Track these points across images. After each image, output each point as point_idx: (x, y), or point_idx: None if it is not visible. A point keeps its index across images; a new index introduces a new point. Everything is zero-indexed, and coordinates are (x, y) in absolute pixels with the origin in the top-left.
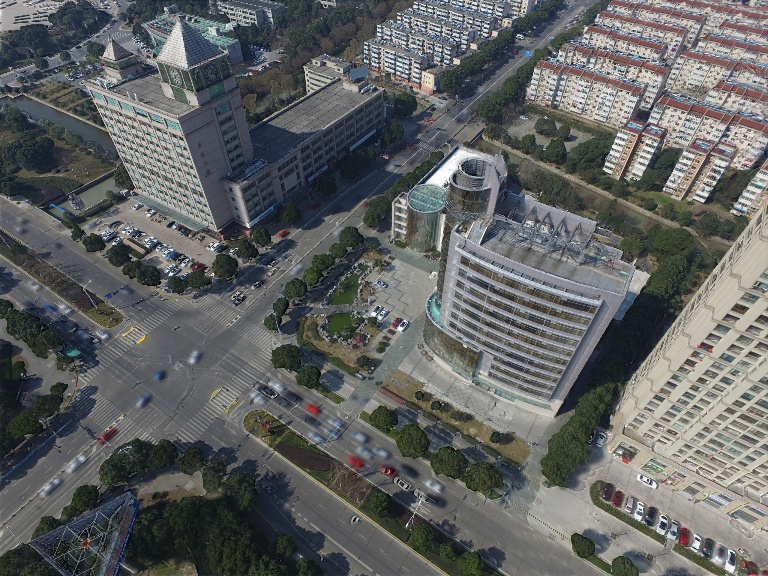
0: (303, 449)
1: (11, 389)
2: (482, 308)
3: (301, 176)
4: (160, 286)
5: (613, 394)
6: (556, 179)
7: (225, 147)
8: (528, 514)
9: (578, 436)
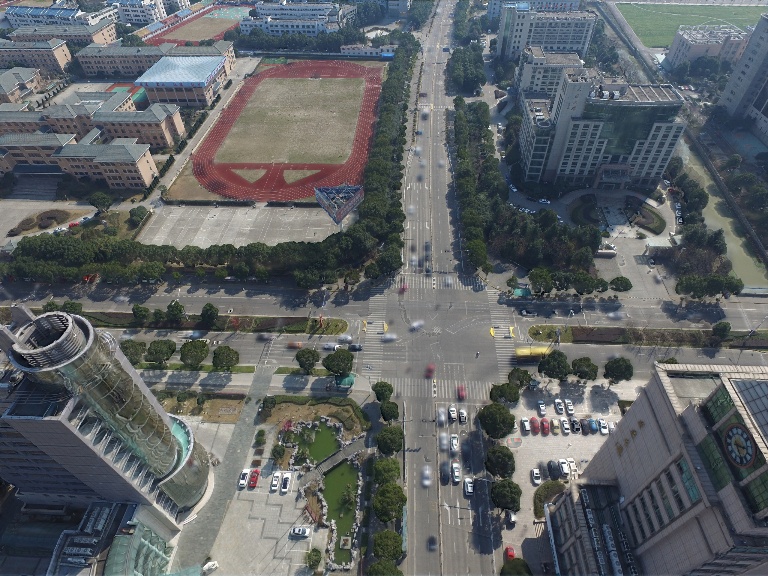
0: (287, 324)
1: (525, 263)
2: None
3: None
4: (550, 384)
5: None
6: None
7: (646, 488)
8: None
9: None
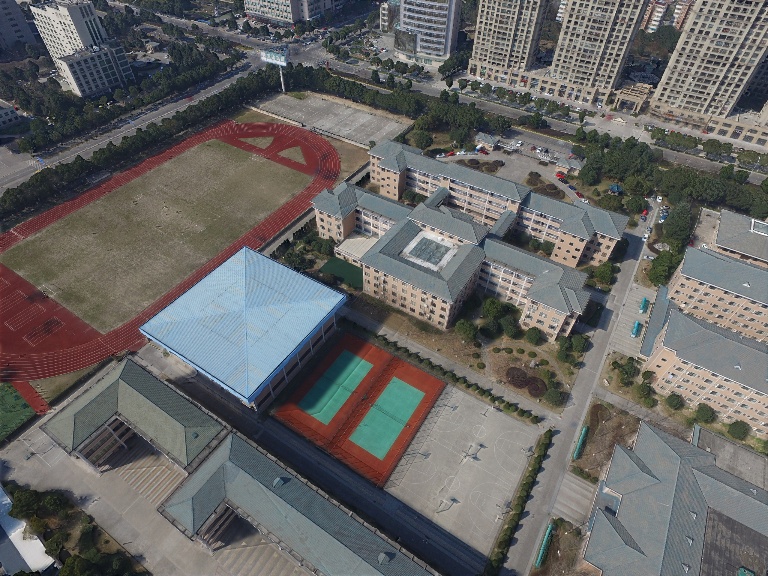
0: None
1: None
2: (414, 3)
3: (333, 4)
4: (268, 41)
5: (471, 54)
6: (466, 7)
7: None
8: (432, 85)
9: (453, 59)
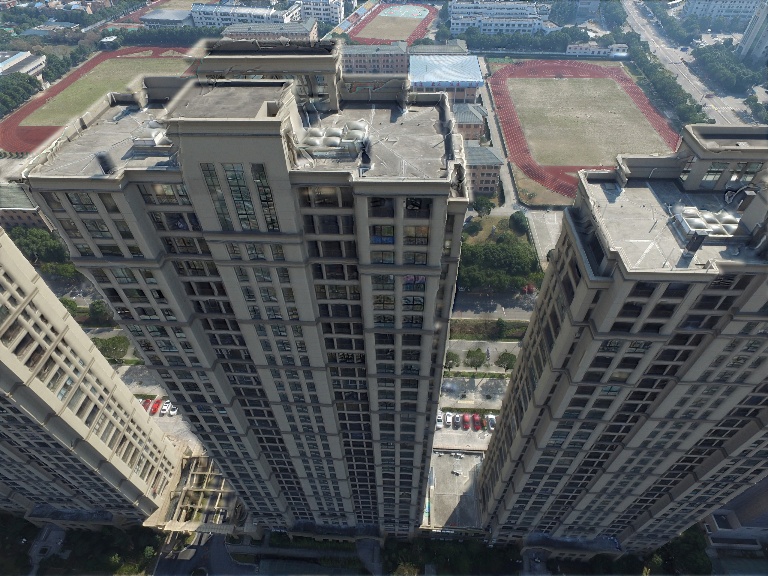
0: None
1: None
2: None
3: None
4: None
5: None
6: None
7: None
8: None
9: None
